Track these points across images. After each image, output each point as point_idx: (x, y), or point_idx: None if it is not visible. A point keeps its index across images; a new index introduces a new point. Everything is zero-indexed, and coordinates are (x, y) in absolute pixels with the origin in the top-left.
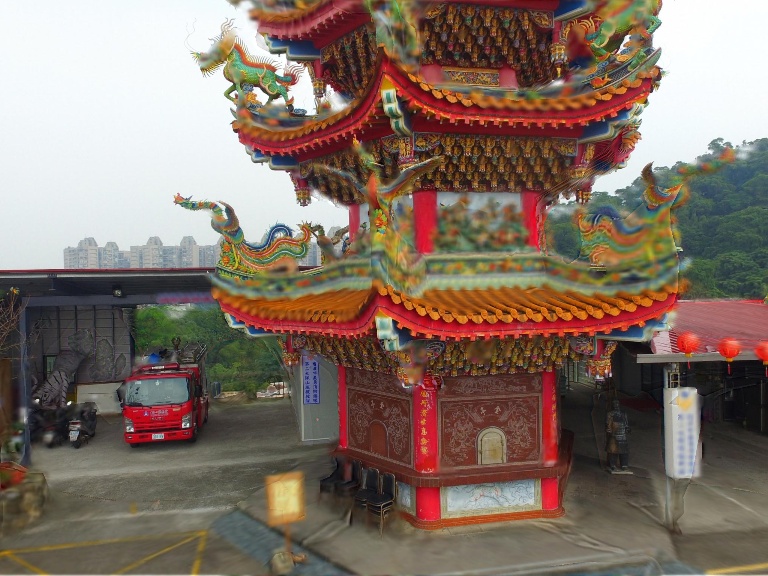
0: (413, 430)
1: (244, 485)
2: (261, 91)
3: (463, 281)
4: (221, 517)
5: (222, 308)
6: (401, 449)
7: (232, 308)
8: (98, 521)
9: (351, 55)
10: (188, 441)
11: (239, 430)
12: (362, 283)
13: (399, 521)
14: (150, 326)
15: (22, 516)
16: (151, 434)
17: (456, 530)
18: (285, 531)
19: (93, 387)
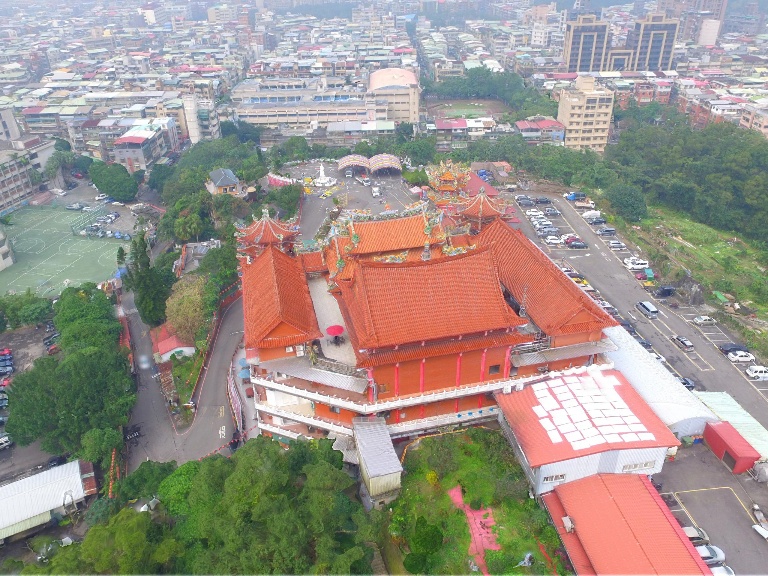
0: None
1: None
2: None
3: None
4: None
5: None
6: None
7: None
8: None
9: None
10: None
11: None
12: None
13: None
14: None
15: None
16: None
17: None
18: None
19: None
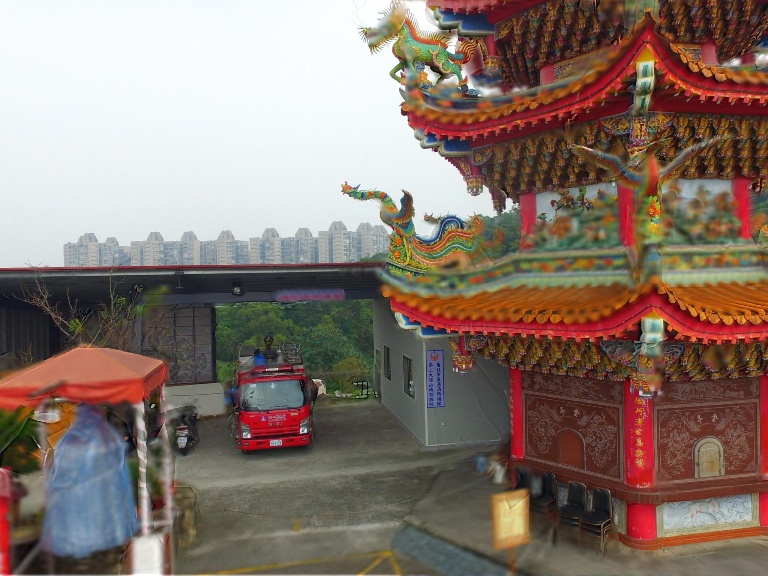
0: (623, 440)
1: (395, 497)
2: (430, 70)
3: (679, 277)
4: (396, 535)
5: (392, 307)
6: (605, 461)
7: (407, 307)
8: (263, 540)
9: (535, 30)
10: (306, 447)
11: (345, 434)
12: (546, 279)
13: (616, 541)
14: (243, 325)
15: (184, 536)
16: (268, 440)
17: (678, 550)
18: (484, 552)
19: (176, 389)
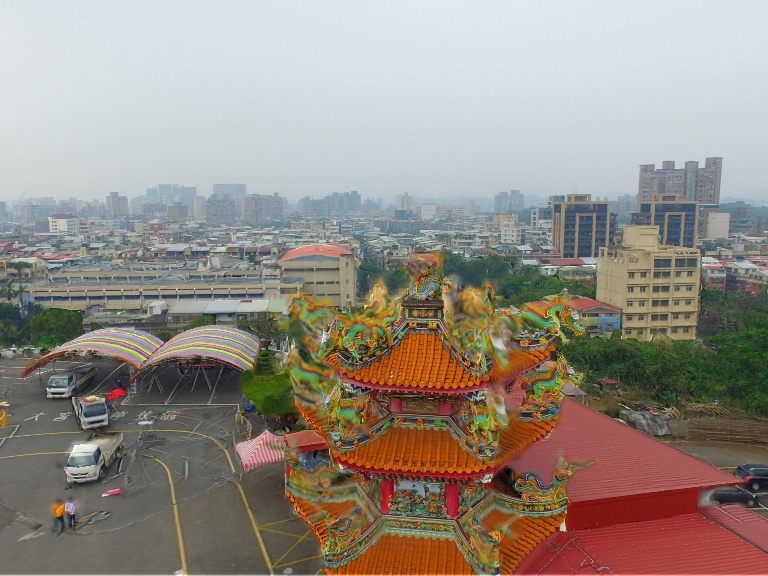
0: None
1: None
2: None
3: None
4: None
5: None
6: None
7: None
8: None
9: None
10: None
11: None
12: None
13: None
14: None
15: None
16: None
17: None
18: None
19: None
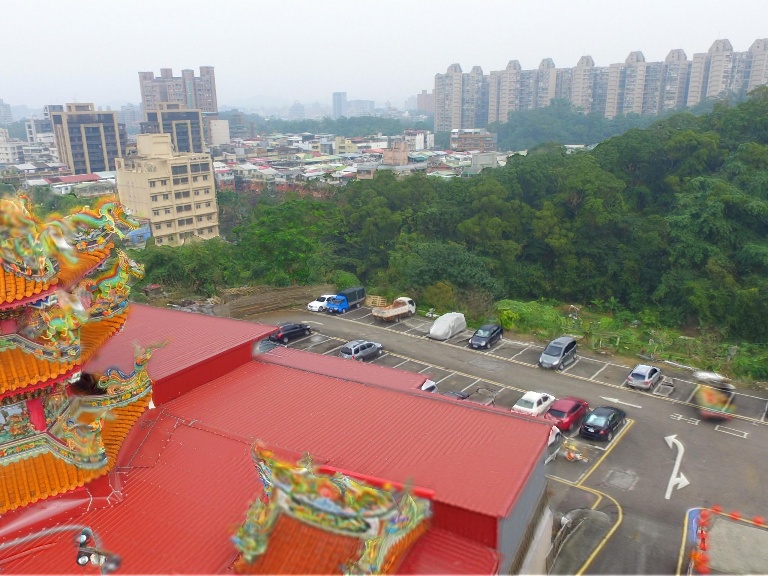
0: None
1: None
2: None
3: None
4: None
5: None
6: None
7: None
8: None
9: None
10: None
11: None
12: None
13: None
14: None
15: None
16: None
17: None
18: None
19: None
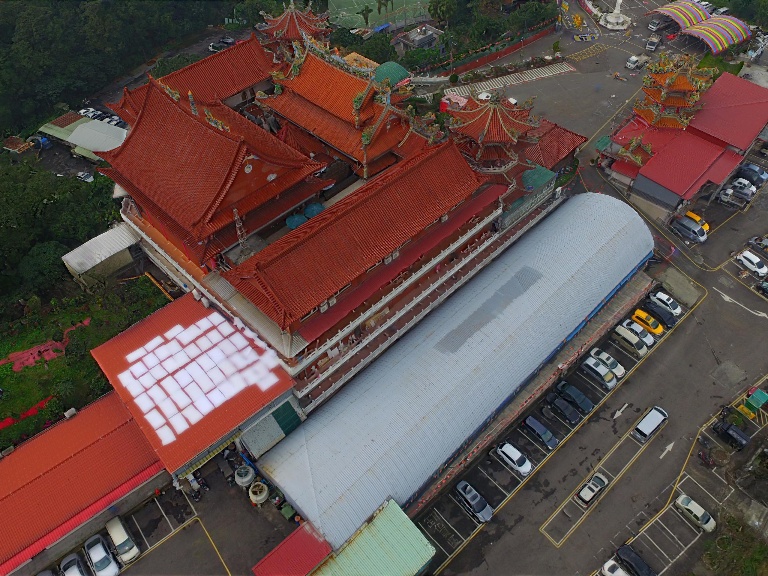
0: None
1: None
2: None
3: None
4: None
5: None
6: None
7: None
8: None
9: None
10: None
11: None
12: None
13: None
14: None
15: None
16: None
17: None
18: None
19: None
